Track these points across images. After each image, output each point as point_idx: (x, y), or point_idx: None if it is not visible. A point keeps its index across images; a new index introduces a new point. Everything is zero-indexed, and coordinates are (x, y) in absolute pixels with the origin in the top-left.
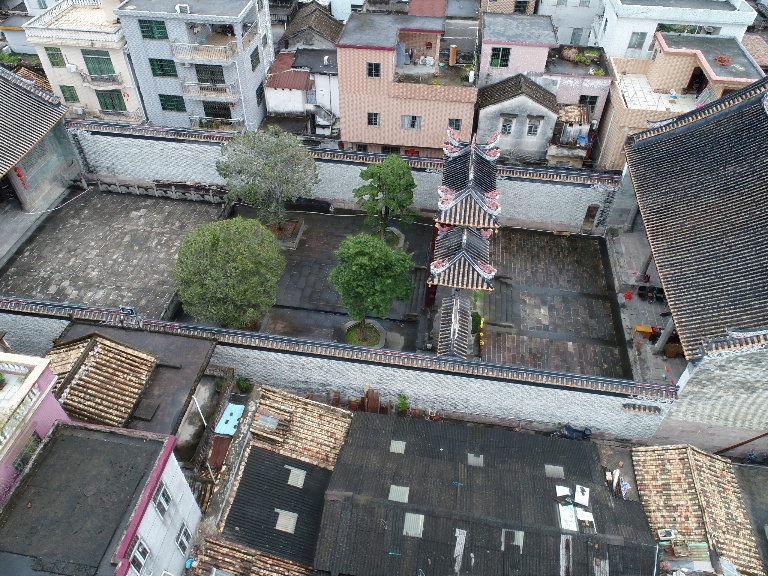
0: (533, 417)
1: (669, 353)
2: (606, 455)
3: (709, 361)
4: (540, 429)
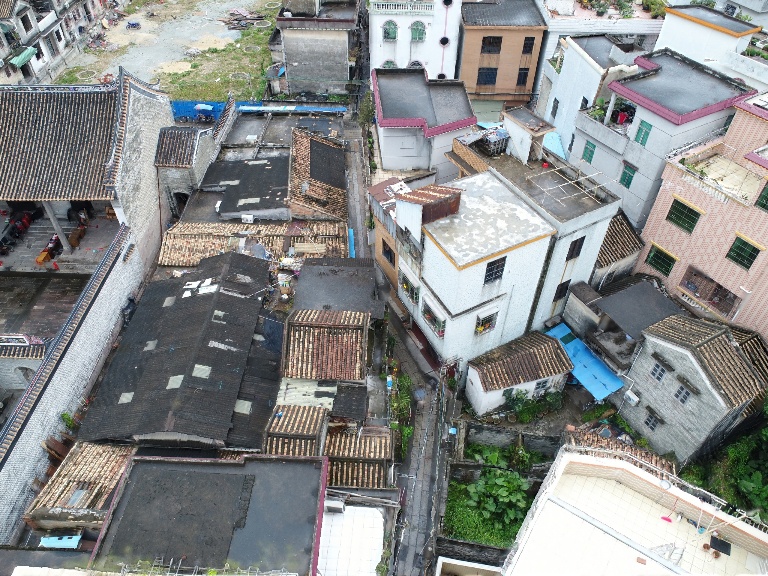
0: (110, 327)
1: (75, 244)
2: (160, 279)
3: (118, 190)
4: (118, 331)
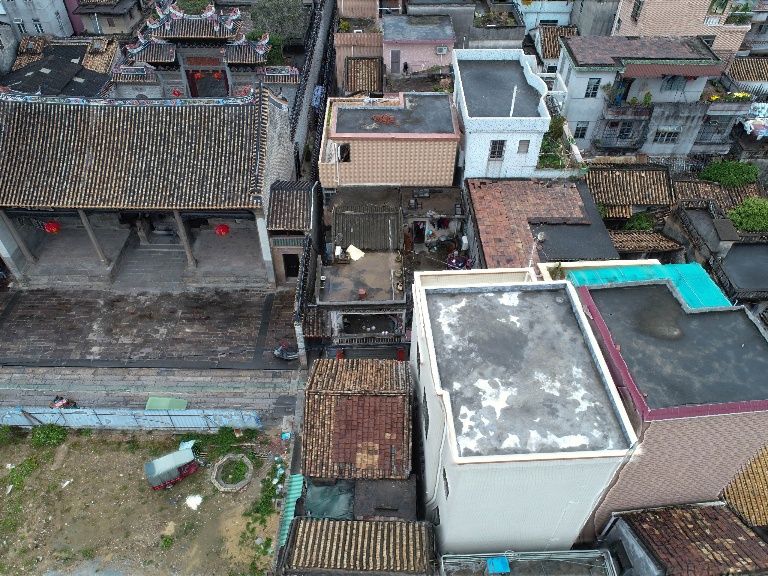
0: None
1: None
2: None
3: None
4: None
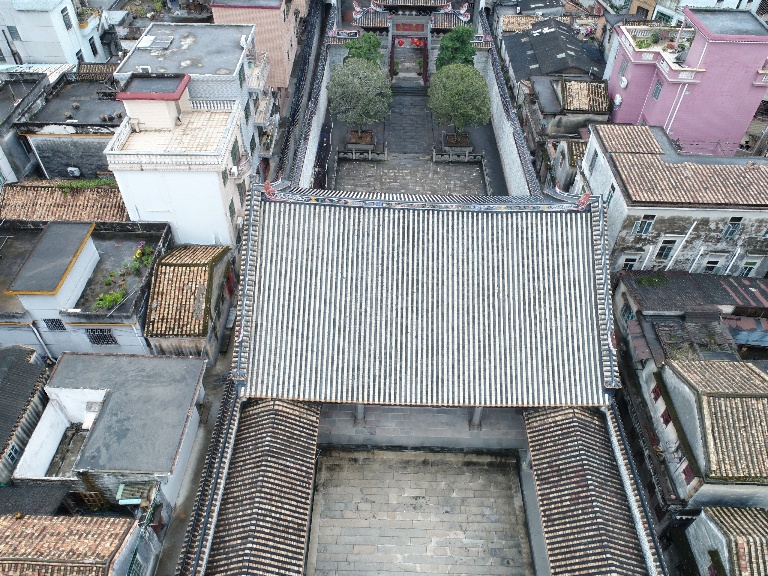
0: None
1: None
2: None
3: None
4: None
